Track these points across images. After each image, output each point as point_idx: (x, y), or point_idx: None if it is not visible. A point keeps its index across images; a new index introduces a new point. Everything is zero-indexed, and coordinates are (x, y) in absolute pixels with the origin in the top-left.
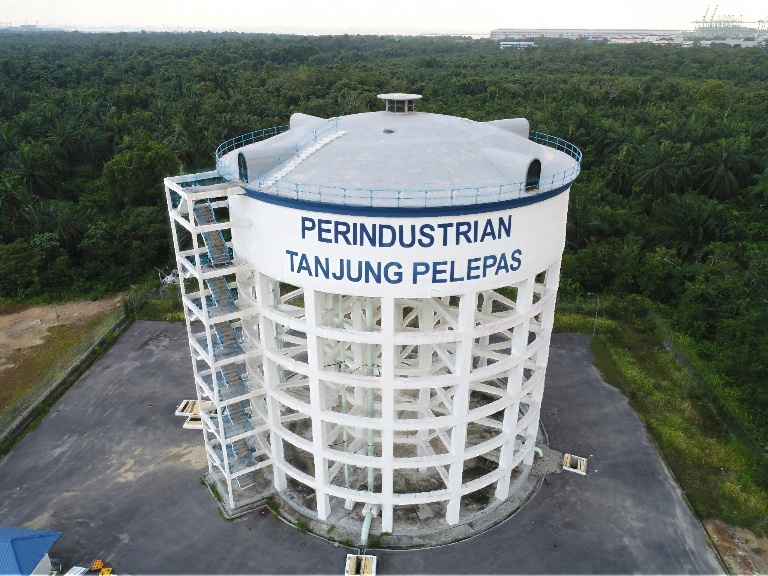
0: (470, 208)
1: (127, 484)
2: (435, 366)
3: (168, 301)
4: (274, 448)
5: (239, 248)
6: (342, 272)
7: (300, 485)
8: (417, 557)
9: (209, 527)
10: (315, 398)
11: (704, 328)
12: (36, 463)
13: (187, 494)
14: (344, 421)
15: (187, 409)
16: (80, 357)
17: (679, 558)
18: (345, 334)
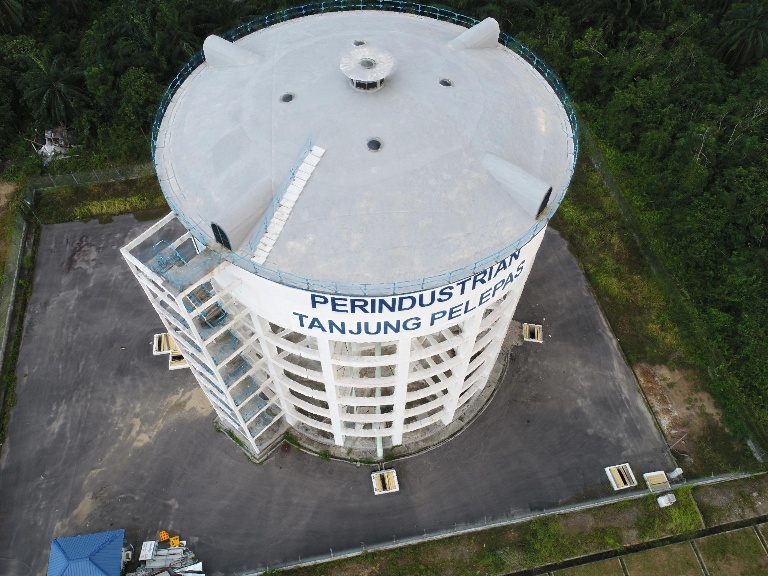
0: None
1: (147, 448)
2: None
3: (64, 187)
4: (285, 407)
5: (222, 284)
6: (359, 330)
7: (309, 414)
8: (426, 460)
9: (244, 475)
10: (331, 394)
11: (629, 140)
12: (42, 445)
13: (209, 446)
14: (361, 404)
15: (163, 347)
16: (9, 300)
17: (618, 409)
18: (362, 363)
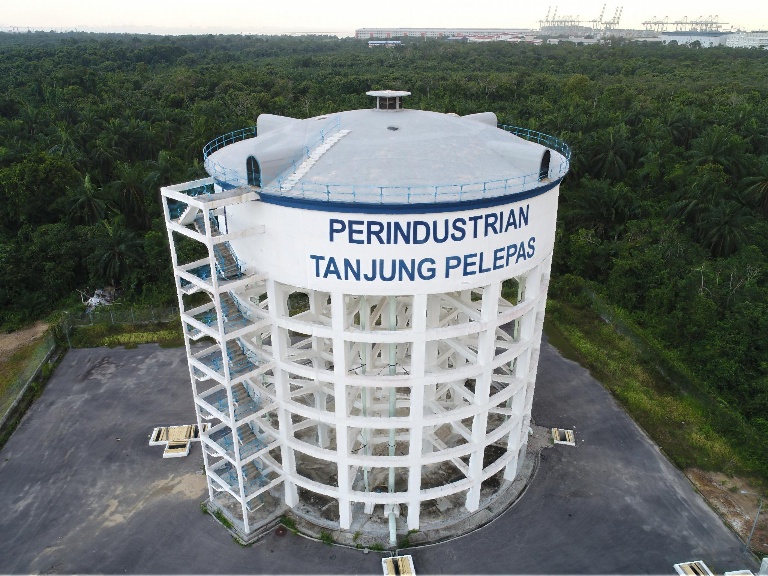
0: (499, 200)
1: (118, 527)
2: (439, 359)
3: (100, 325)
4: (287, 463)
5: (244, 257)
6: (374, 273)
7: (311, 498)
8: (449, 549)
9: (227, 557)
10: (341, 405)
11: (635, 299)
12: None
13: (191, 527)
14: (373, 424)
15: (162, 437)
16: (16, 397)
17: (676, 507)
18: (376, 335)
